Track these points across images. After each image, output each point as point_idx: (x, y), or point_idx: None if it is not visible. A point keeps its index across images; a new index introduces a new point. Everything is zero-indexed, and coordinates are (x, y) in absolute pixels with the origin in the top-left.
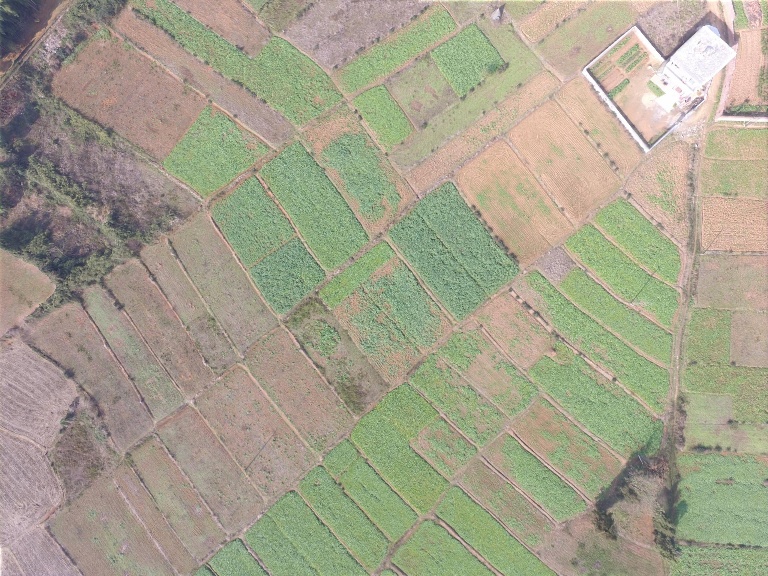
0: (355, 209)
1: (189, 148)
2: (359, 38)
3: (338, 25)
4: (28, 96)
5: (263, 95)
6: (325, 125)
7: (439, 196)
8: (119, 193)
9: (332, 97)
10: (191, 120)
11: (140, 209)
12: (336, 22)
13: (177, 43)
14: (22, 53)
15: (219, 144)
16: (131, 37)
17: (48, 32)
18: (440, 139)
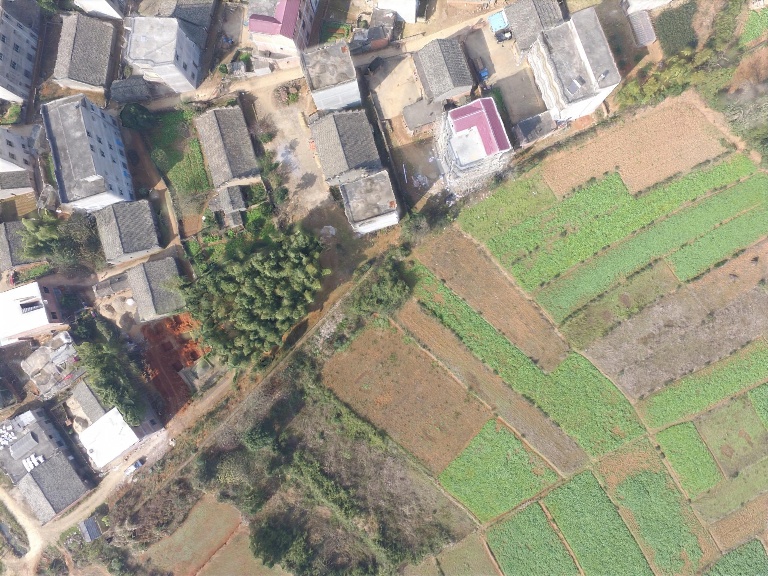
0: (650, 558)
1: (470, 465)
2: (670, 367)
3: (648, 350)
4: (295, 381)
5: (557, 418)
6: (622, 457)
7: (744, 554)
8: (388, 503)
9: (635, 430)
10: (473, 432)
11: (409, 524)
12: (645, 346)
13: (464, 345)
14: (296, 338)
15: (503, 465)
16: (414, 332)
17: (324, 317)
18: (752, 492)
